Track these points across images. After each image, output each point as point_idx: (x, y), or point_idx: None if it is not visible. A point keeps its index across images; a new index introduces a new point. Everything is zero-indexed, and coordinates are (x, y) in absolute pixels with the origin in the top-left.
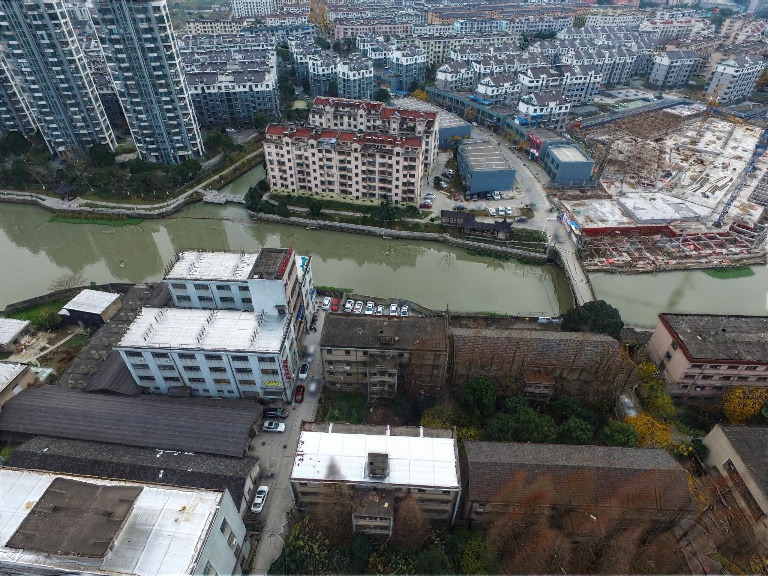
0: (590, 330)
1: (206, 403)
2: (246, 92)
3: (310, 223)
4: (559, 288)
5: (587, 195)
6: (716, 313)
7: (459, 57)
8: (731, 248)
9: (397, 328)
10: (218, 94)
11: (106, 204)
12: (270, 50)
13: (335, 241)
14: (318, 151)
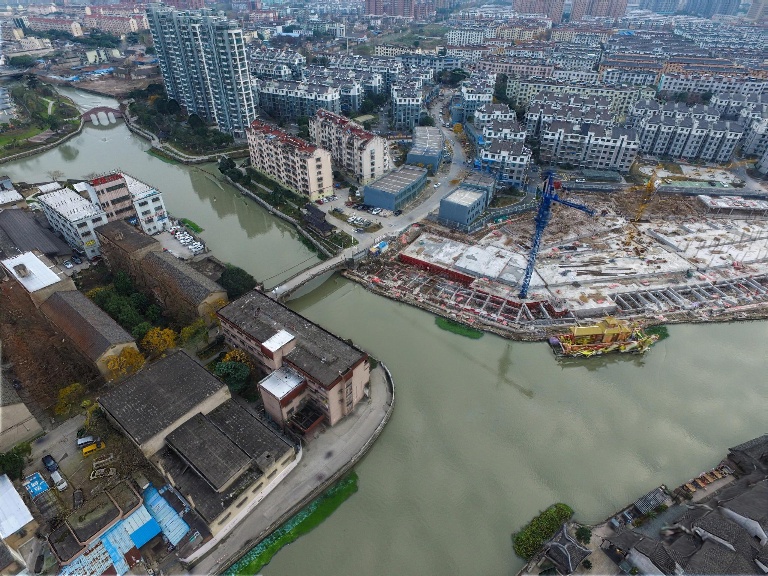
0: (222, 284)
1: (57, 242)
2: (312, 100)
3: (243, 190)
4: (324, 283)
5: (452, 235)
6: (384, 341)
7: (534, 102)
8: (494, 314)
9: (132, 236)
10: (295, 98)
11: (173, 149)
12: (377, 73)
13: (259, 209)
14: (266, 142)
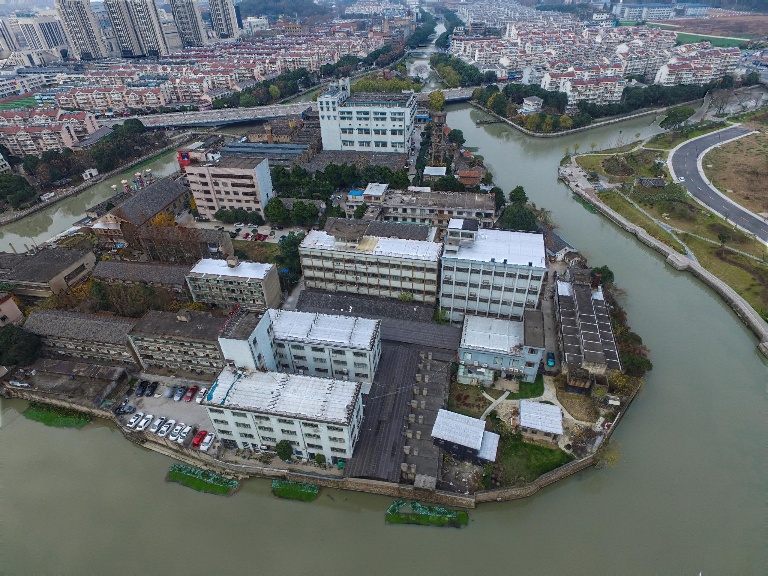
0: None
1: None
2: None
3: None
4: None
5: None
6: None
7: None
8: None
9: (172, 326)
10: None
11: None
12: None
13: None
14: None
